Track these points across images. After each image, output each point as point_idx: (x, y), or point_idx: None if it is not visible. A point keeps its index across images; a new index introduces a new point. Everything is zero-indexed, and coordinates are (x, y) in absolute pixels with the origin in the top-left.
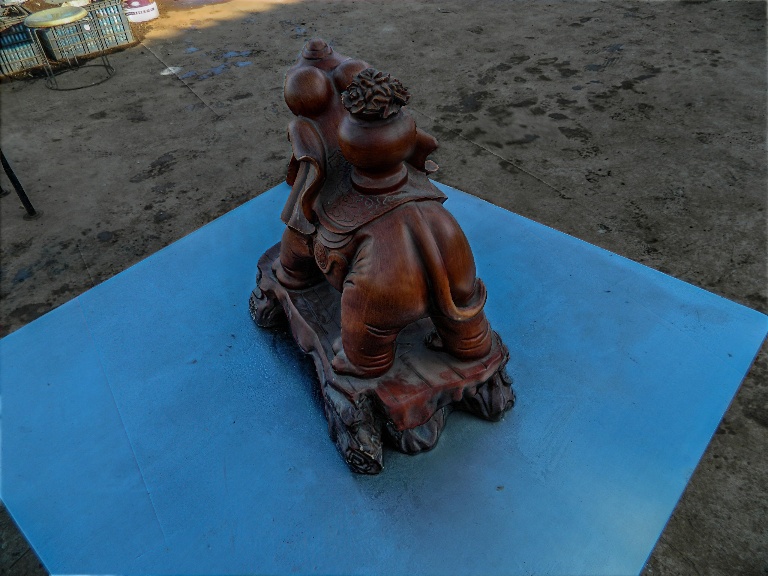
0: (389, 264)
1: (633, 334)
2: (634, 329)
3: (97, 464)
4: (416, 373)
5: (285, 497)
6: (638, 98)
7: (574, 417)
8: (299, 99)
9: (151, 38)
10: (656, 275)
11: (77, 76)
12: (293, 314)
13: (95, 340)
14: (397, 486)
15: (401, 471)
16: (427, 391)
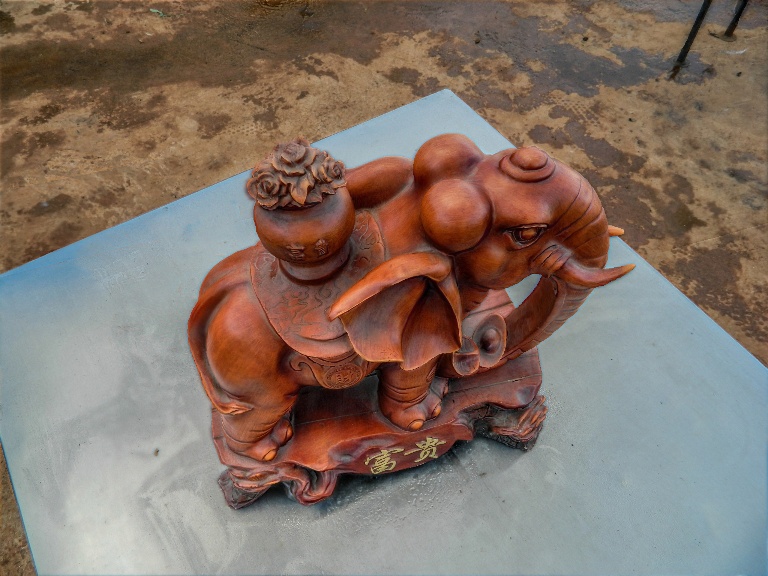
0: None
1: None
2: None
3: None
4: None
5: None
6: None
7: (187, 570)
8: None
9: None
10: None
11: None
12: None
13: None
14: None
15: None
16: None
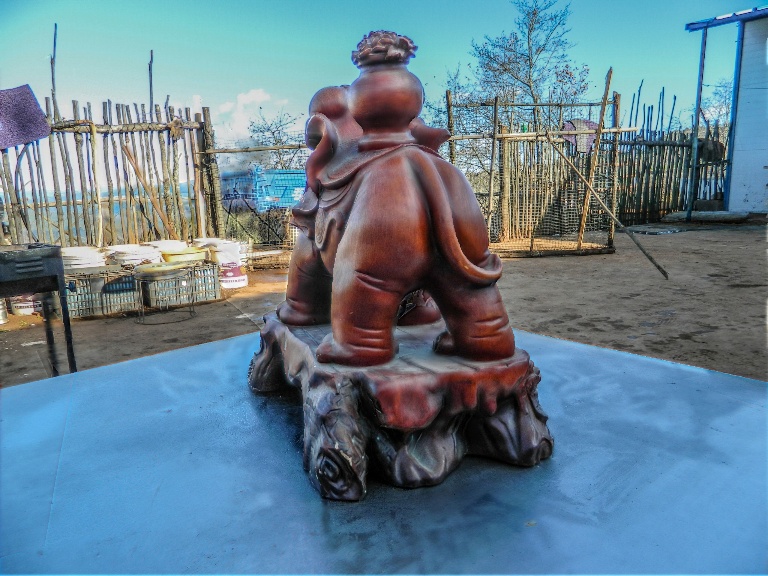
0: (384, 186)
1: (711, 411)
2: (711, 408)
3: (8, 477)
4: (418, 366)
5: (224, 515)
6: (698, 345)
7: (638, 469)
8: (320, 101)
9: (236, 297)
10: (732, 376)
11: (163, 317)
12: (288, 340)
13: (73, 395)
14: (381, 513)
15: (390, 501)
16: (428, 375)
